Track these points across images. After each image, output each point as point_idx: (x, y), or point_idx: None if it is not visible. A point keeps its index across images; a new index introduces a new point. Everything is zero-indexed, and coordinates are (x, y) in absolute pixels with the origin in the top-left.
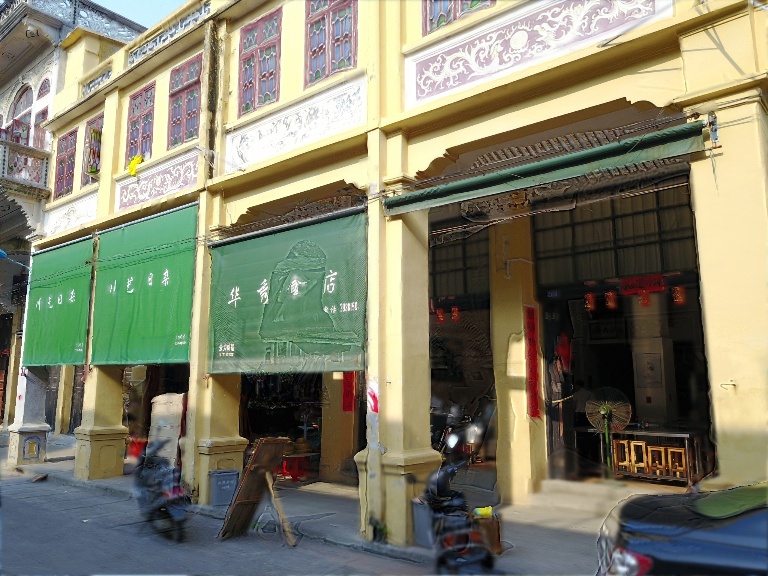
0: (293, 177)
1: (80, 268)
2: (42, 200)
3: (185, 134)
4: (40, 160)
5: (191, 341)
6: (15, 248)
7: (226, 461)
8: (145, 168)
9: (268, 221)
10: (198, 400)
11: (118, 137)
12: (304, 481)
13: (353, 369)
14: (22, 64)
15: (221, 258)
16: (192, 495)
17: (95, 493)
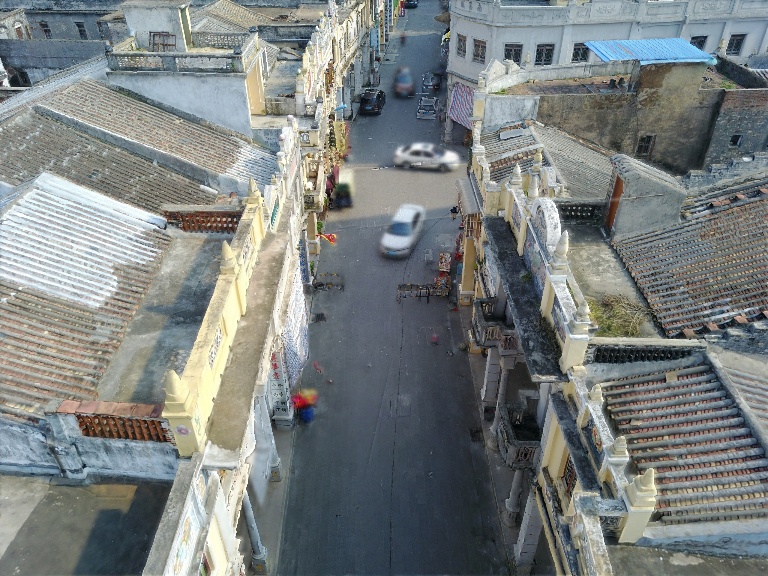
0: None
1: None
2: None
3: None
4: None
5: None
6: None
7: None
8: None
9: None
10: None
11: None
12: None
13: None
14: None
15: None
16: None
17: None
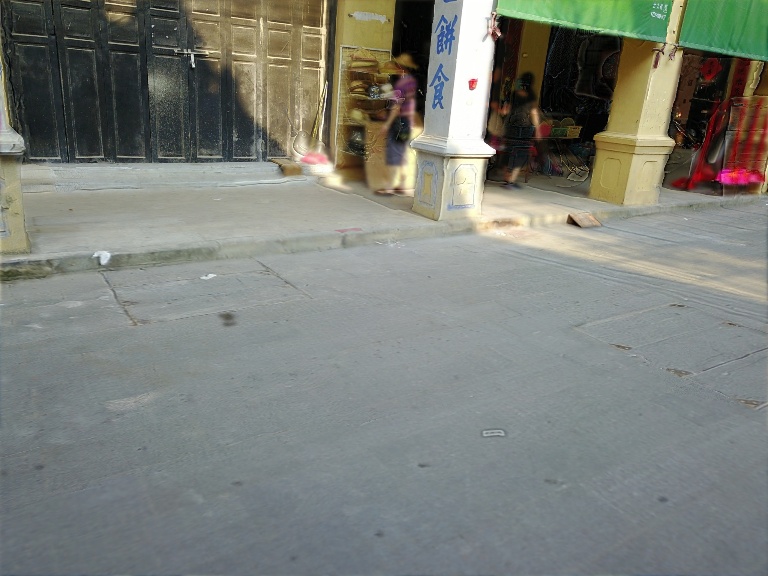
0: None
1: None
2: None
3: None
4: None
5: None
6: None
7: None
8: None
9: None
10: None
11: None
12: None
13: None
14: None
15: None
16: None
17: (688, 213)
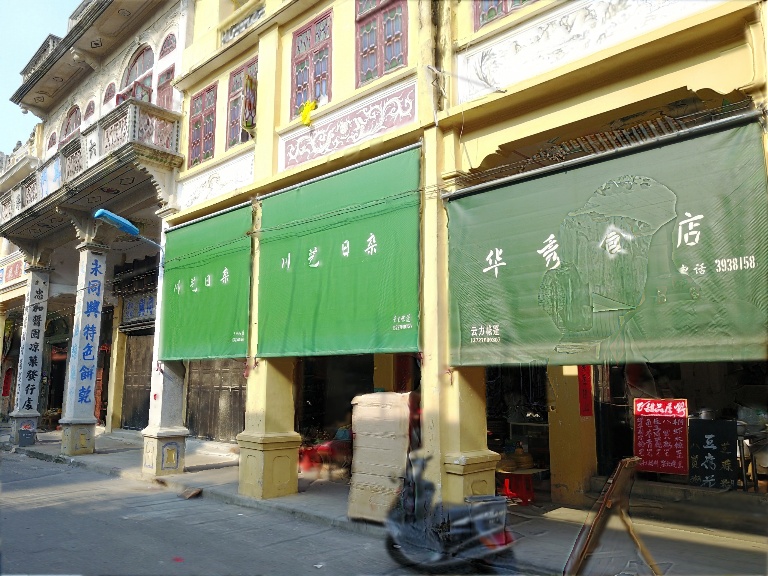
0: (585, 94)
1: (235, 242)
2: (174, 169)
3: (384, 64)
4: (170, 123)
5: (424, 323)
6: None
7: (479, 483)
8: (322, 114)
9: (518, 165)
10: (441, 401)
11: (279, 83)
12: (540, 506)
13: (590, 362)
14: (138, 23)
15: (466, 212)
16: (441, 529)
17: (278, 517)
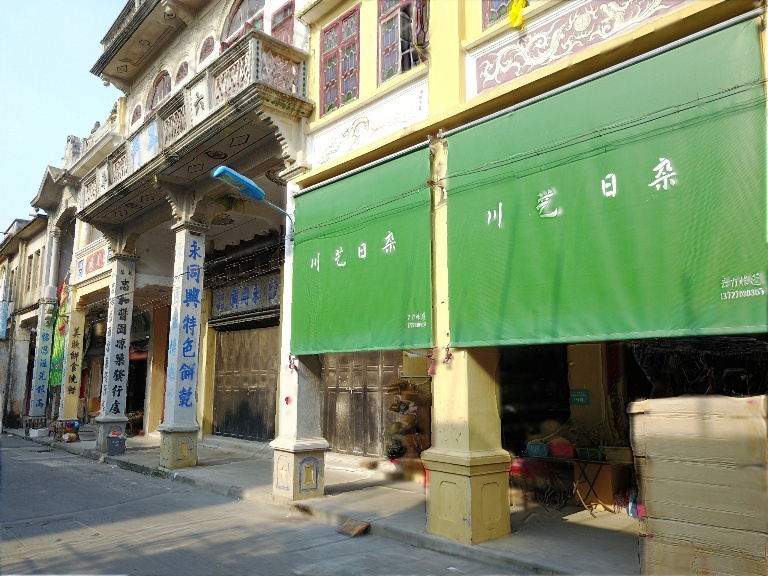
0: None
1: (404, 197)
2: (302, 119)
3: None
4: (295, 65)
5: None
6: (226, 209)
7: None
8: (541, 11)
9: None
10: None
11: None
12: None
13: None
14: None
15: None
16: None
17: (511, 574)
